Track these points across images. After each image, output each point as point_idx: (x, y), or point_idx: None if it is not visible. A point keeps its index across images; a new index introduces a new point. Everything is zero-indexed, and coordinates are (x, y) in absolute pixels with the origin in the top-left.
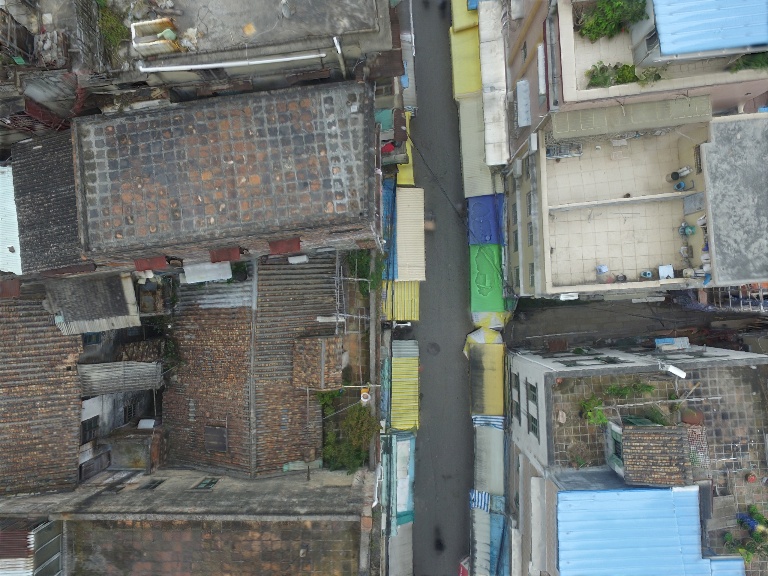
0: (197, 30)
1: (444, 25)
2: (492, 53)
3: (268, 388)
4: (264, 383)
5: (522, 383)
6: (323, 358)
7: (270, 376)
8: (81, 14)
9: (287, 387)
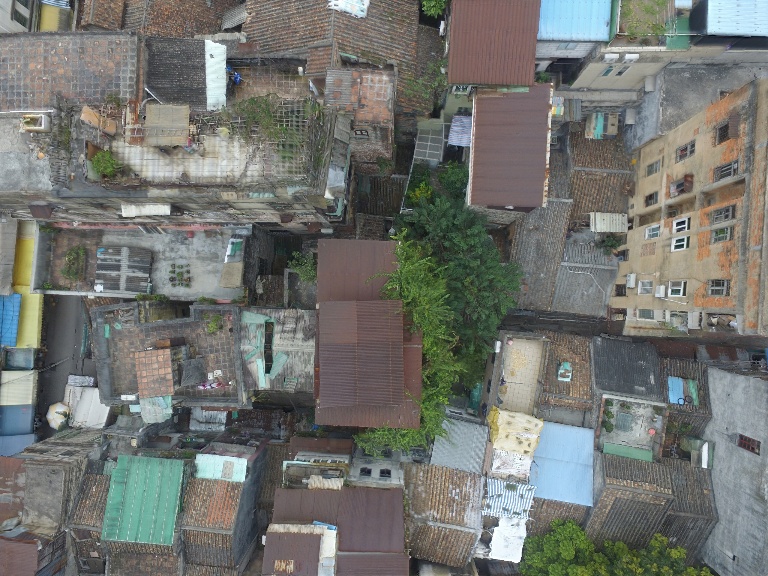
0: (19, 131)
1: (66, 313)
2: (5, 255)
3: (140, 0)
4: (141, 3)
5: (5, 9)
6: (91, 11)
7: (138, 8)
8: (56, 125)
9: (131, 2)
